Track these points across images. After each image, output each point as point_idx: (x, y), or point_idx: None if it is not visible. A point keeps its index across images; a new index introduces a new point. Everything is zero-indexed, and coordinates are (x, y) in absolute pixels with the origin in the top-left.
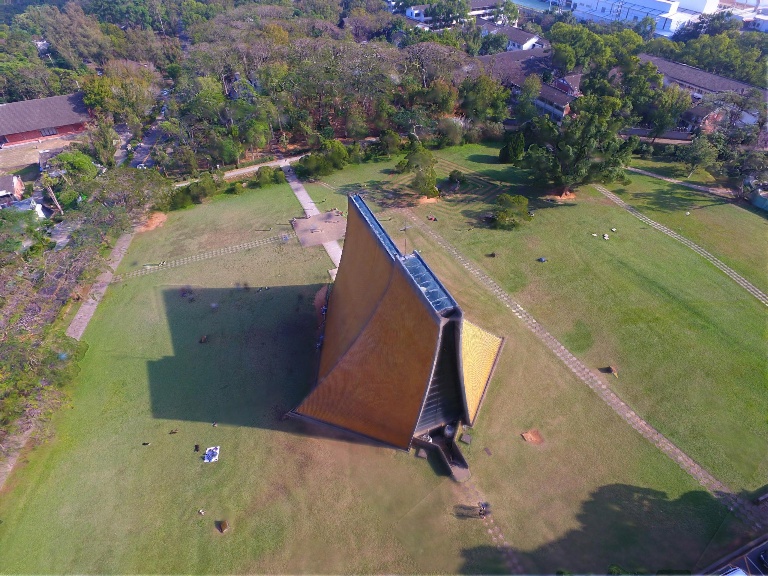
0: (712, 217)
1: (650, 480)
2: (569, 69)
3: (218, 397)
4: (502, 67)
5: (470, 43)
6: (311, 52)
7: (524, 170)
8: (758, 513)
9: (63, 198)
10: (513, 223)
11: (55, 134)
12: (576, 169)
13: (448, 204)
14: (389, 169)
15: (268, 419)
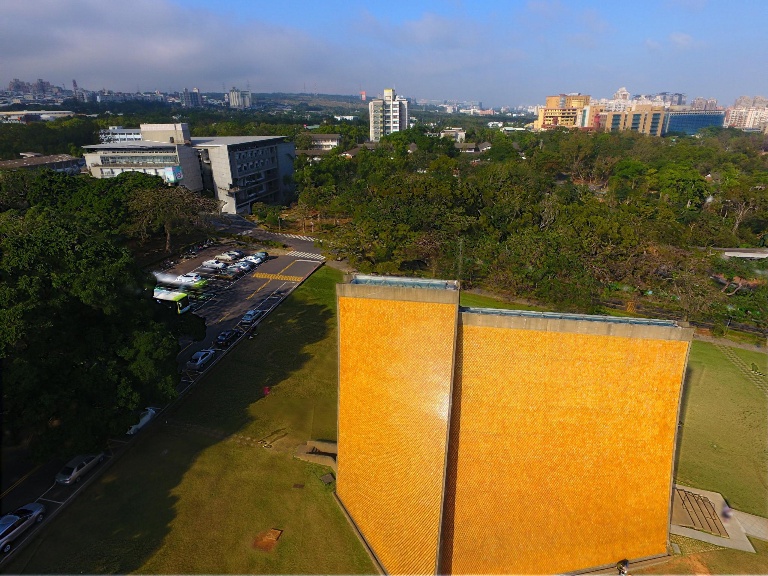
0: None
1: None
2: None
3: None
4: None
5: None
6: None
7: None
8: None
9: None
10: None
11: None
12: None
13: None
14: None
15: None
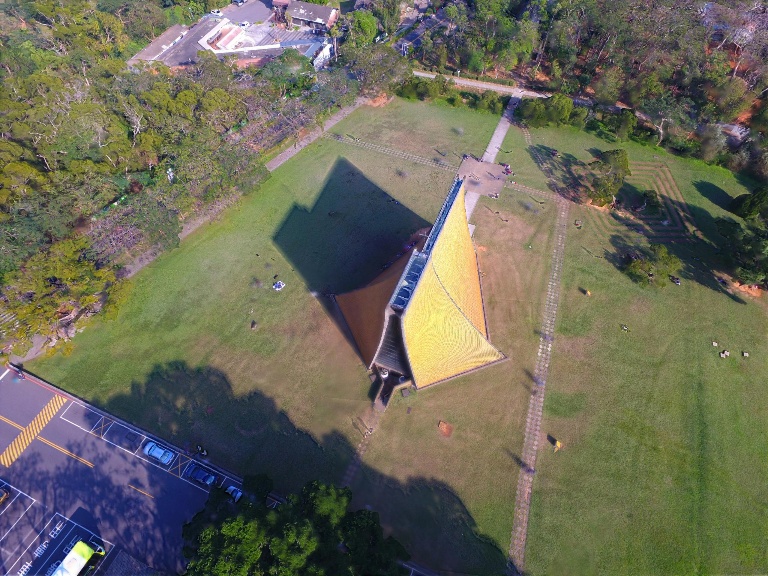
0: None
1: (481, 517)
2: None
3: (308, 256)
4: None
5: None
6: None
7: None
8: None
9: None
10: (647, 277)
11: None
12: None
13: (610, 220)
14: (600, 151)
15: (319, 289)
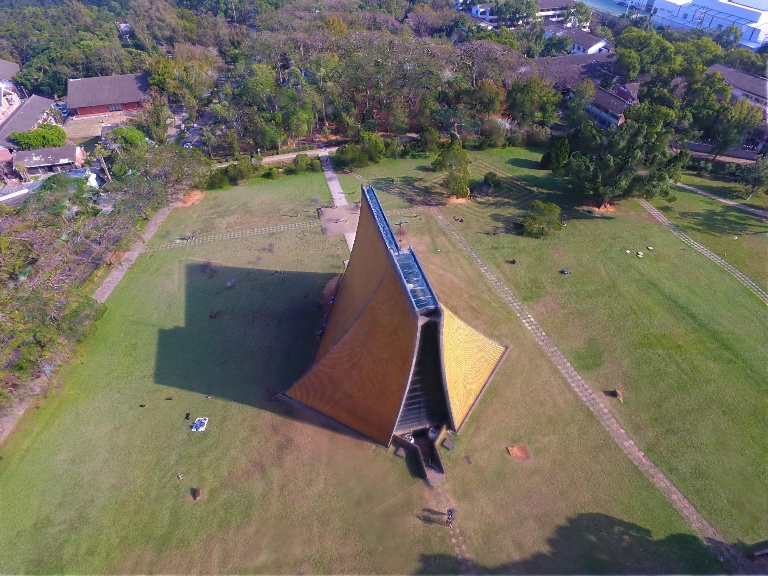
0: (765, 245)
1: (636, 515)
2: (632, 76)
3: (216, 371)
4: (559, 70)
5: (531, 44)
6: (365, 45)
7: (565, 178)
8: (751, 569)
9: (114, 170)
10: (542, 231)
11: (121, 110)
12: (617, 181)
13: (478, 206)
14: (425, 166)
15: (258, 398)
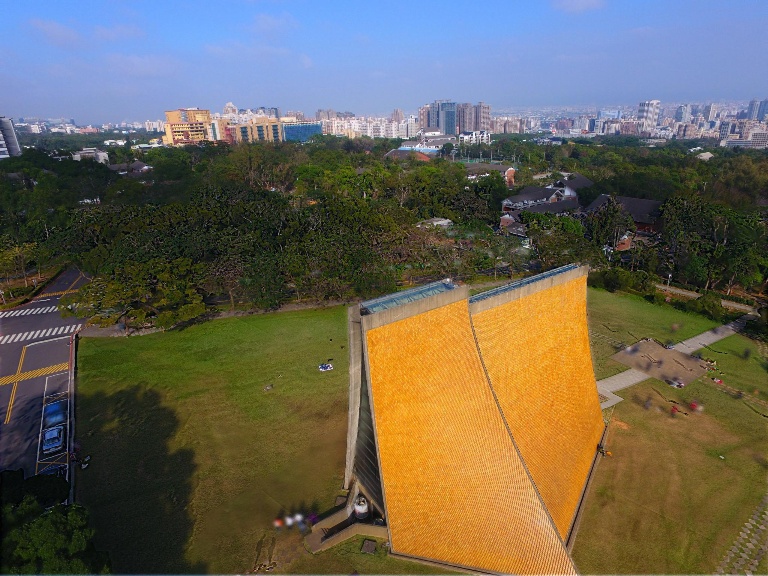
0: None
1: None
2: None
3: None
4: None
5: None
6: None
7: None
8: None
9: None
10: None
11: None
12: None
13: None
14: None
15: None
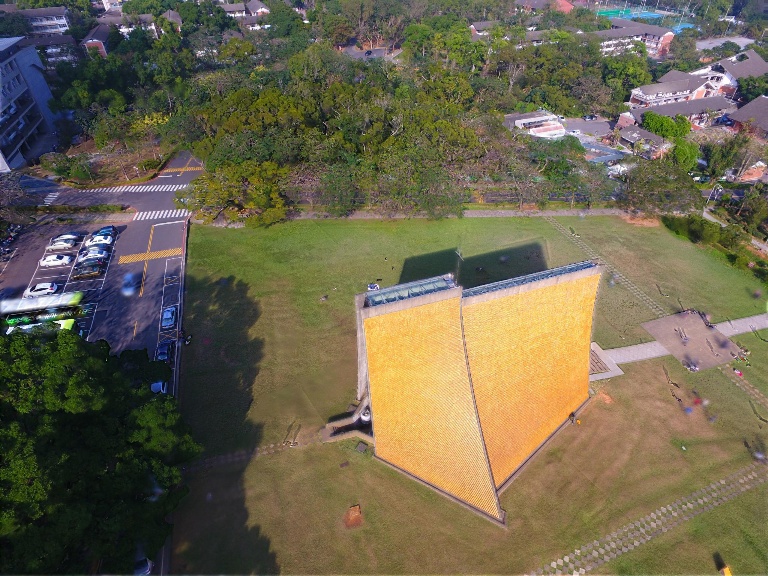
0: None
1: None
2: None
3: None
4: None
5: None
6: None
7: None
8: None
9: None
10: None
11: None
12: None
13: None
14: None
15: None
